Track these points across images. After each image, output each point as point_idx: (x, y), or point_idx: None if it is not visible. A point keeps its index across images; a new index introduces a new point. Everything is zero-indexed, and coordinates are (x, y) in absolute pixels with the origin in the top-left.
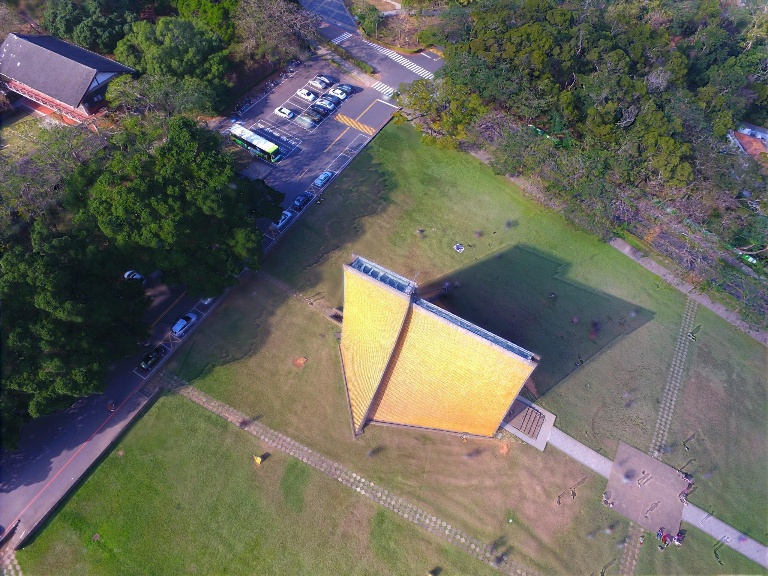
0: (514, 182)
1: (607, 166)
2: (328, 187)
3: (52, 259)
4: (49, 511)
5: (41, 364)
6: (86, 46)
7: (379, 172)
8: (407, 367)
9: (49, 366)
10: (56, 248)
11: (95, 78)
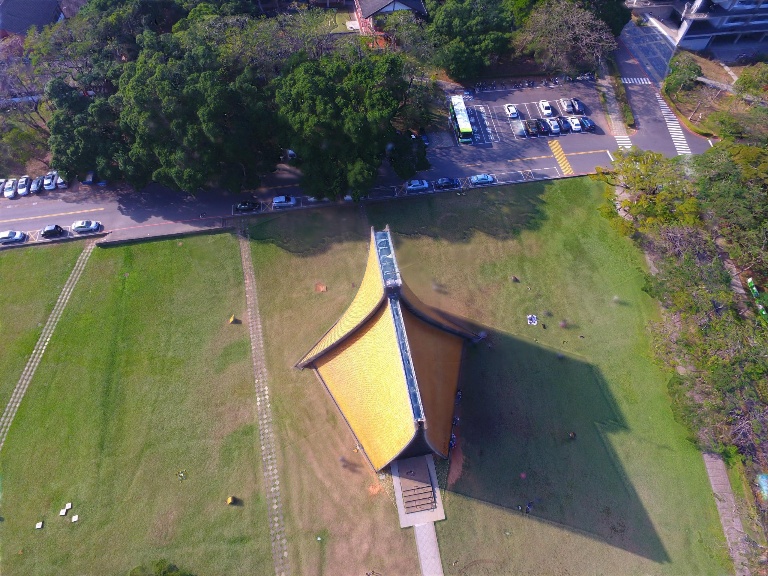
0: None
1: None
2: (479, 188)
3: (236, 95)
4: (124, 240)
5: (177, 151)
6: None
7: (535, 208)
8: (361, 350)
9: (178, 155)
10: (242, 89)
11: (394, 5)
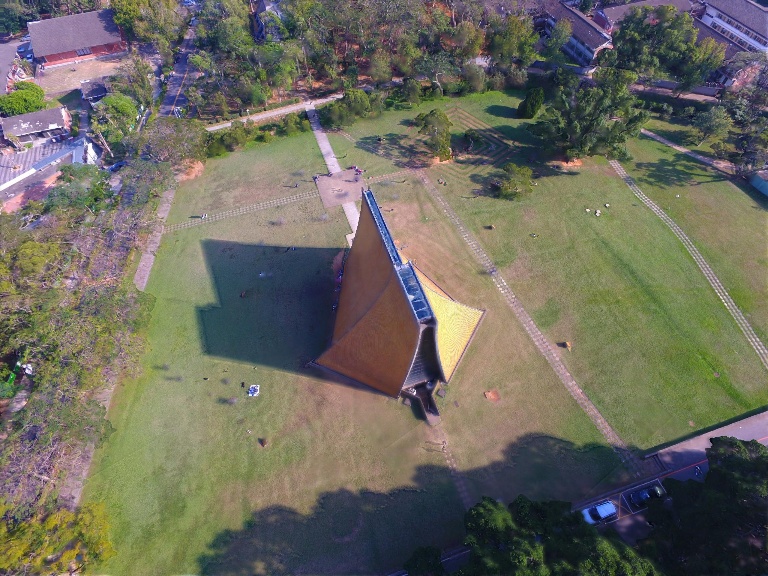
0: None
1: None
2: None
3: None
4: (762, 413)
5: None
6: None
7: None
8: None
9: None
10: None
11: None
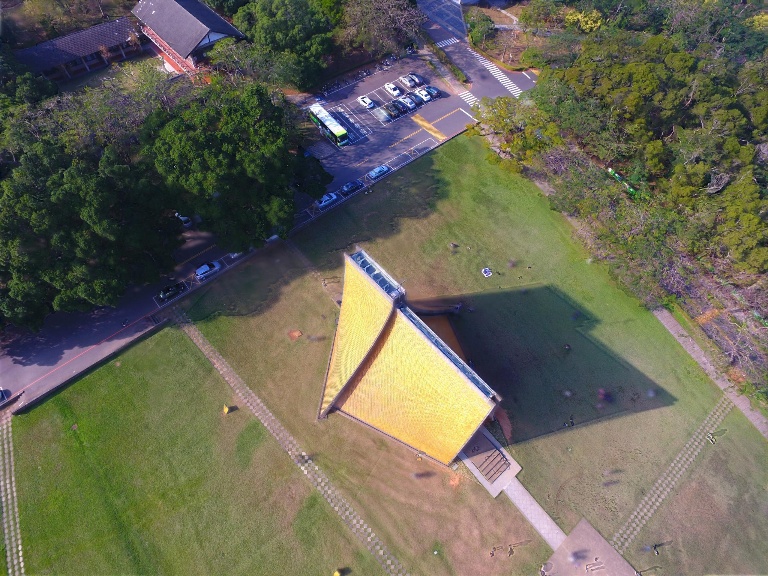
0: (570, 222)
1: (671, 229)
2: (380, 181)
3: (109, 182)
4: (47, 392)
5: (72, 267)
6: (213, 7)
7: (435, 178)
8: (382, 369)
9: (77, 270)
10: (115, 173)
11: (208, 36)
